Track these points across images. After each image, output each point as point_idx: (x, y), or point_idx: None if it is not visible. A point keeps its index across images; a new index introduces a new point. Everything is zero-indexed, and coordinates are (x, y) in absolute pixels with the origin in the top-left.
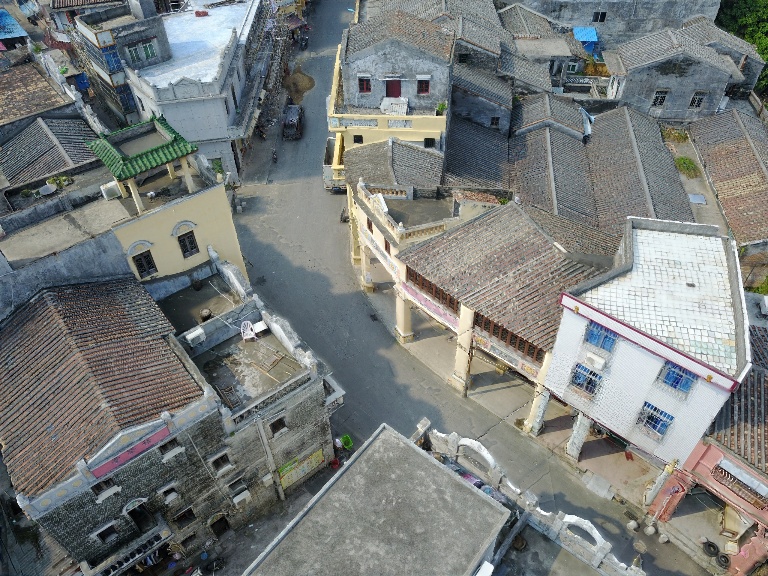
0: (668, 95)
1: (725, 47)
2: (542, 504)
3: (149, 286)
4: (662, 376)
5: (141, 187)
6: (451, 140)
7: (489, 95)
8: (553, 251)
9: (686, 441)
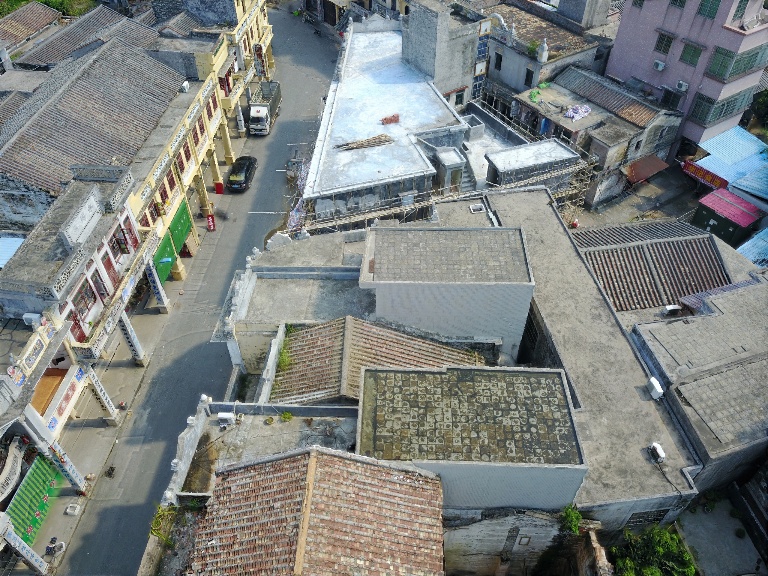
0: None
1: None
2: None
3: None
4: None
5: None
6: None
7: None
8: None
9: None
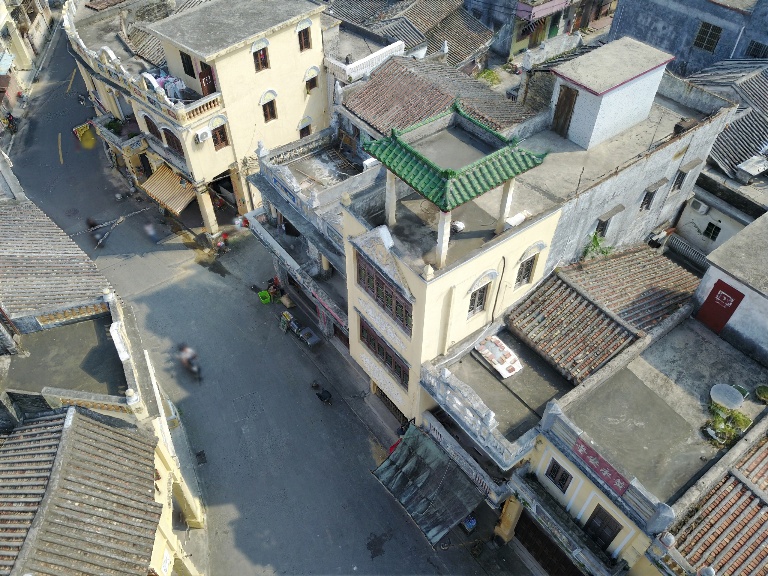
0: None
1: None
2: (110, 254)
3: None
4: None
5: None
6: None
7: None
8: None
9: None
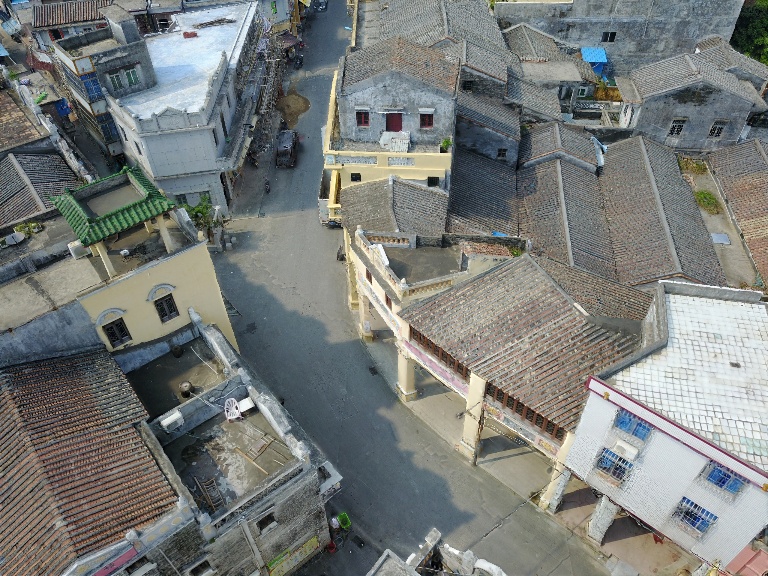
0: (686, 124)
1: (746, 73)
2: None
3: (122, 356)
4: (705, 473)
5: (114, 243)
6: (455, 174)
7: (496, 125)
8: (573, 313)
9: (731, 543)
